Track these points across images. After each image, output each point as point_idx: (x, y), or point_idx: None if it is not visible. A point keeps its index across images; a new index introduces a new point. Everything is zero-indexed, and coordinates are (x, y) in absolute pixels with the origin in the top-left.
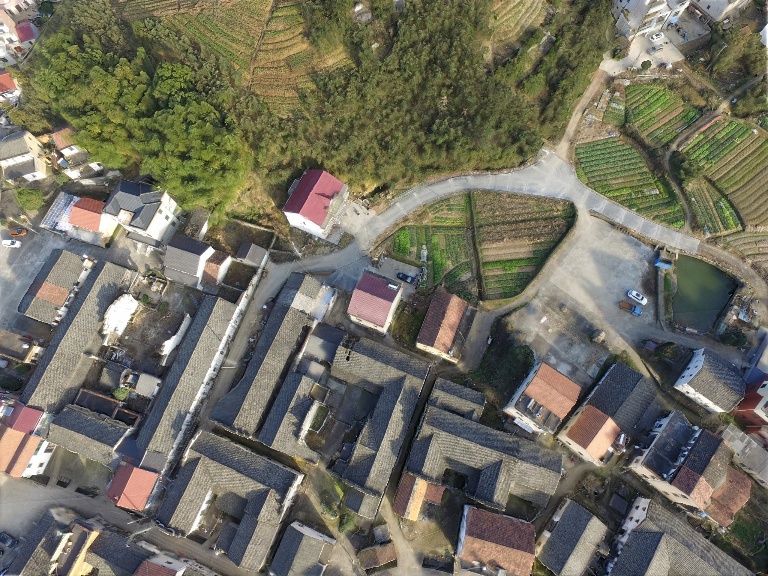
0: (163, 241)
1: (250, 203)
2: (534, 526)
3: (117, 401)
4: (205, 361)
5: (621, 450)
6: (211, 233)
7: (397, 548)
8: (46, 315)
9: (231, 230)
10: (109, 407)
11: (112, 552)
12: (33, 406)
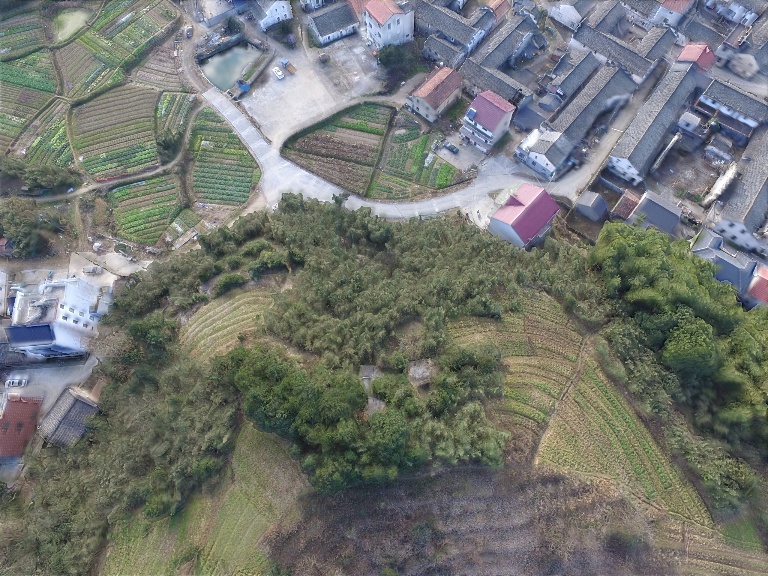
0: None
1: None
2: None
3: None
4: (640, 120)
5: None
6: None
7: None
8: None
9: None
10: (722, 120)
11: (707, 35)
12: None
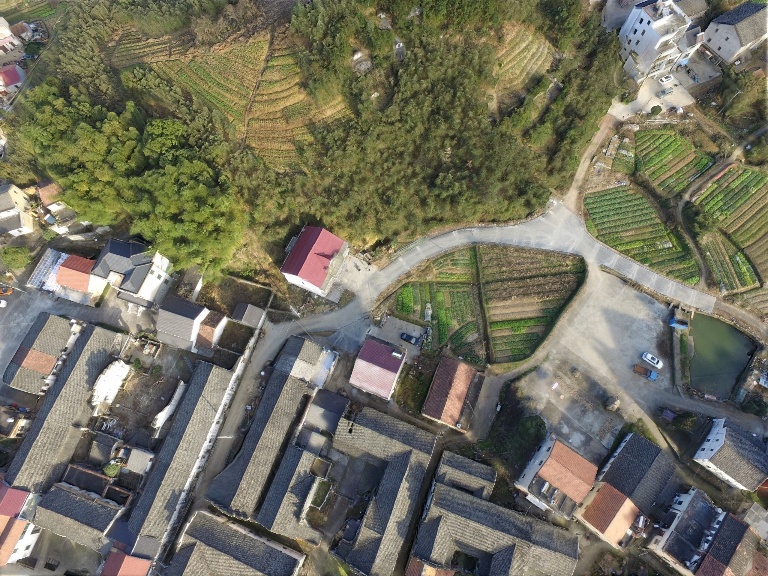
0: (155, 301)
1: (246, 259)
2: None
3: (108, 478)
4: (200, 434)
5: (641, 534)
6: (206, 291)
7: None
8: (32, 385)
9: (226, 287)
10: (99, 484)
11: None
12: (18, 486)
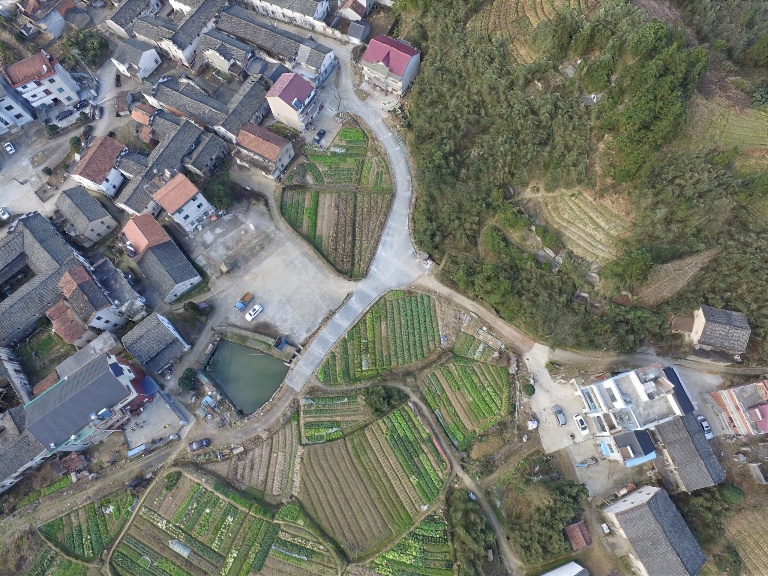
0: None
1: None
2: (99, 184)
3: None
4: None
5: None
6: (386, 8)
7: (126, 117)
8: None
9: (387, 21)
10: None
11: None
12: None
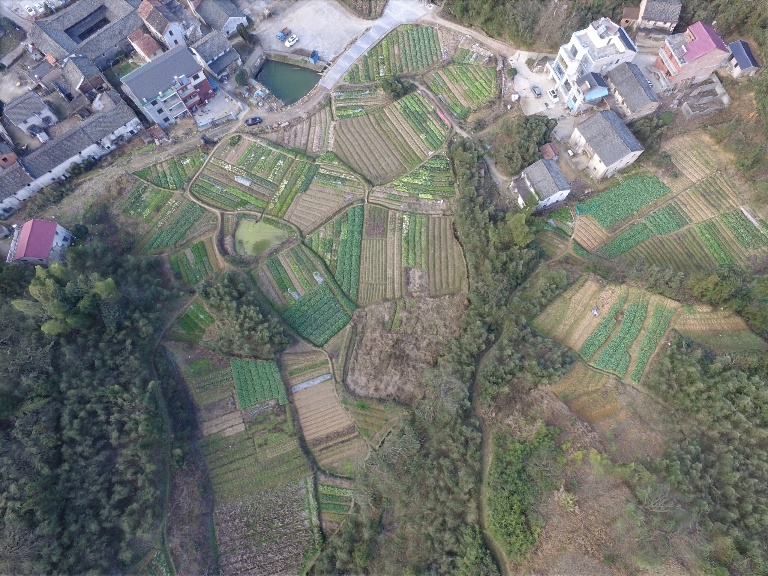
0: None
1: None
2: None
3: None
4: None
5: None
6: None
7: None
8: None
9: None
10: None
11: None
12: None
